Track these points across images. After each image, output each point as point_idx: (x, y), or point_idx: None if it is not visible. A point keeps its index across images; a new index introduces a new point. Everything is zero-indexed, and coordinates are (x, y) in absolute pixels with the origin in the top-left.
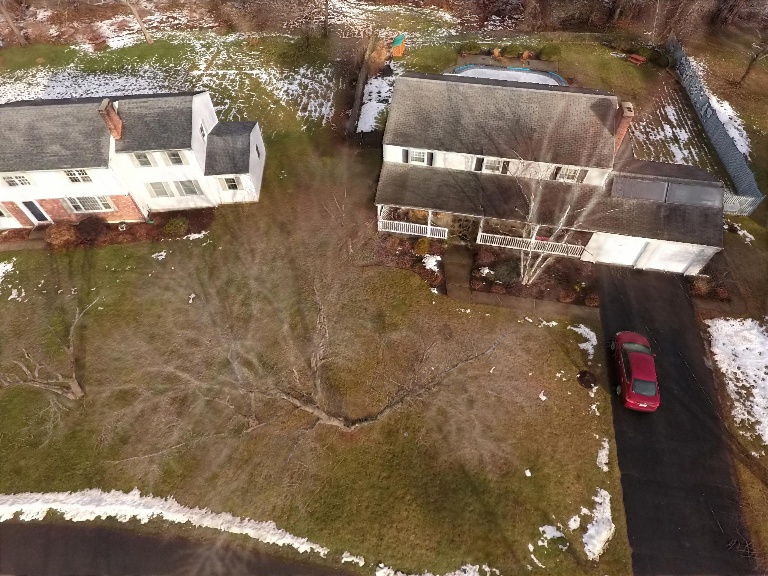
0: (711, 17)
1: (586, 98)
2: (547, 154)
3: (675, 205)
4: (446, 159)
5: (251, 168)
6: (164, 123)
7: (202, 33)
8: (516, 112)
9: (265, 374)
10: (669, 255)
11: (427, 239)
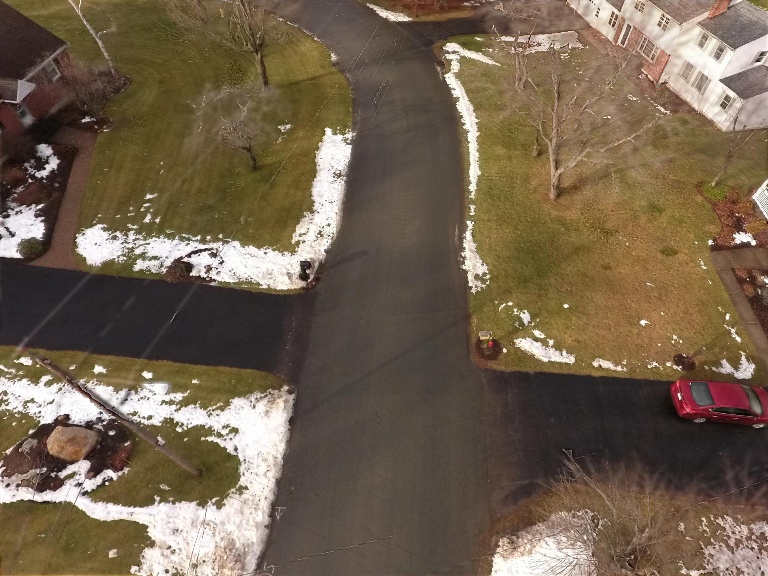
0: None
1: None
2: None
3: None
4: None
5: (752, 103)
6: (745, 27)
7: None
8: None
9: (570, 156)
10: None
11: None
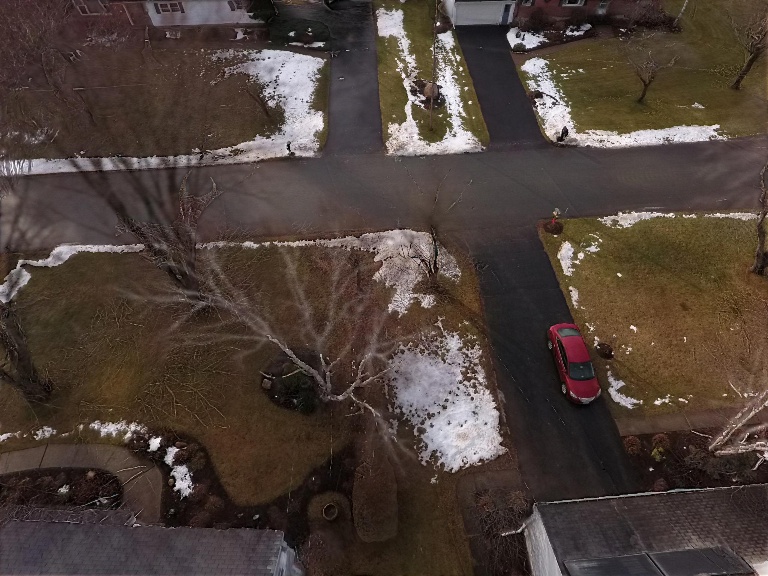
0: None
1: None
2: None
3: None
4: None
5: None
6: None
7: None
8: None
9: None
10: None
11: None
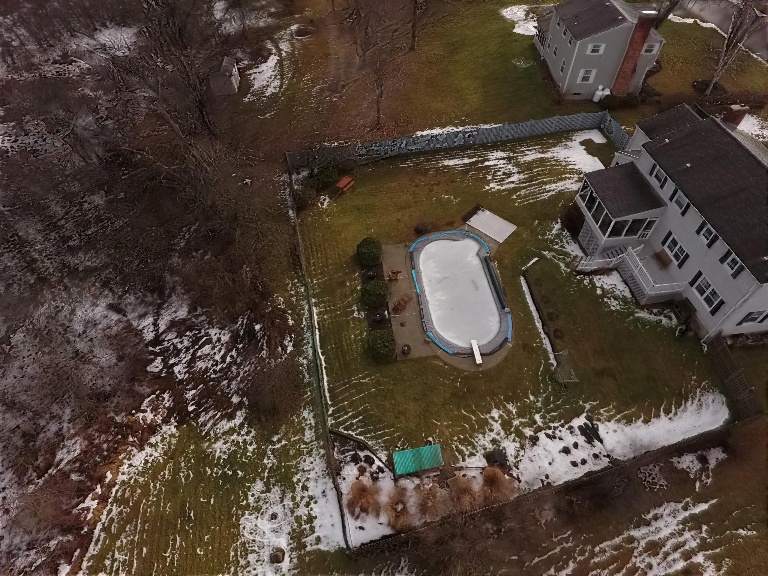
0: None
1: None
2: None
3: None
4: None
5: None
6: None
7: None
8: None
9: None
10: None
11: None
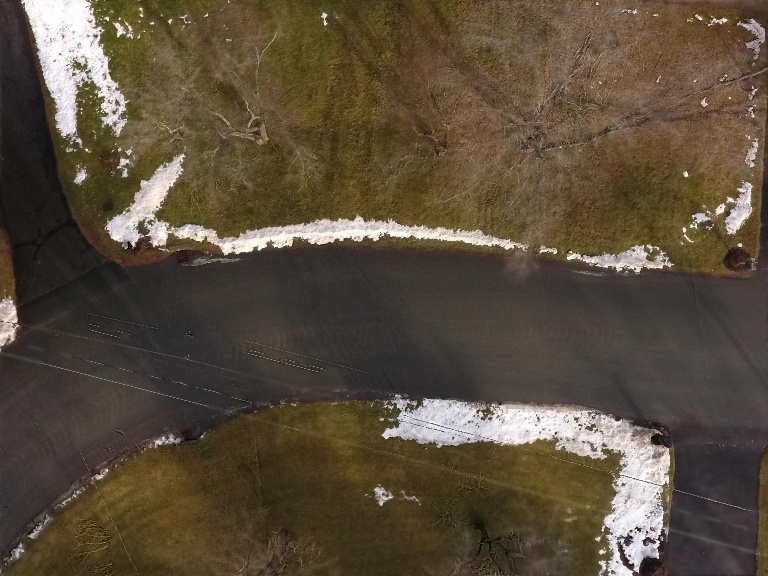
0: None
1: None
2: None
3: None
4: None
5: None
6: None
7: None
8: None
9: None
10: None
11: None
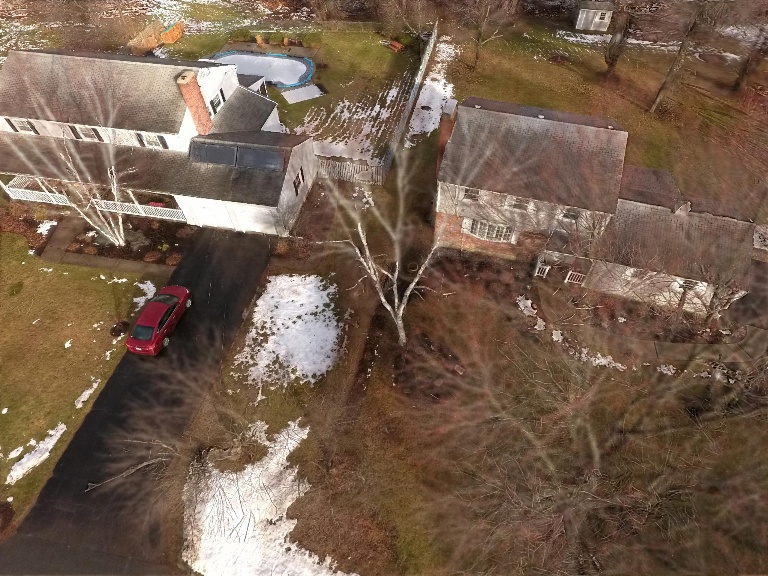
0: (494, 8)
1: (172, 69)
2: (124, 121)
3: (245, 169)
4: (46, 128)
5: None
6: None
7: (6, 22)
8: (108, 83)
9: None
10: (254, 217)
11: (50, 206)
